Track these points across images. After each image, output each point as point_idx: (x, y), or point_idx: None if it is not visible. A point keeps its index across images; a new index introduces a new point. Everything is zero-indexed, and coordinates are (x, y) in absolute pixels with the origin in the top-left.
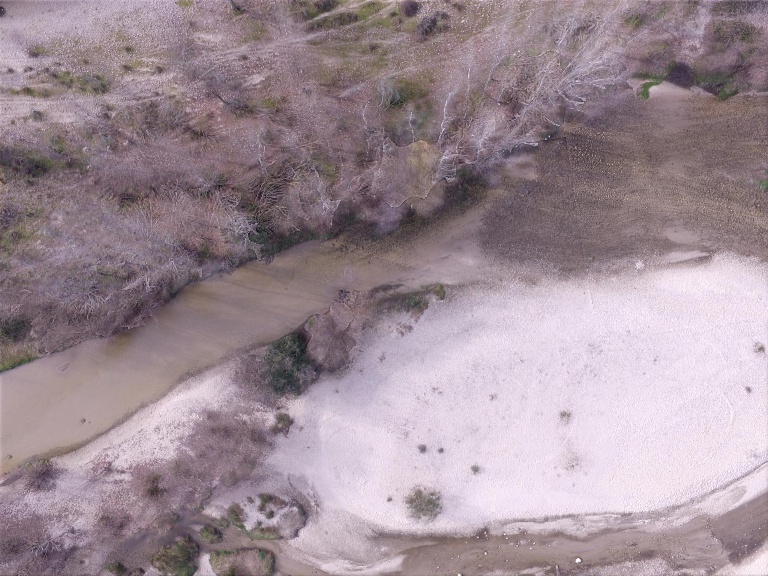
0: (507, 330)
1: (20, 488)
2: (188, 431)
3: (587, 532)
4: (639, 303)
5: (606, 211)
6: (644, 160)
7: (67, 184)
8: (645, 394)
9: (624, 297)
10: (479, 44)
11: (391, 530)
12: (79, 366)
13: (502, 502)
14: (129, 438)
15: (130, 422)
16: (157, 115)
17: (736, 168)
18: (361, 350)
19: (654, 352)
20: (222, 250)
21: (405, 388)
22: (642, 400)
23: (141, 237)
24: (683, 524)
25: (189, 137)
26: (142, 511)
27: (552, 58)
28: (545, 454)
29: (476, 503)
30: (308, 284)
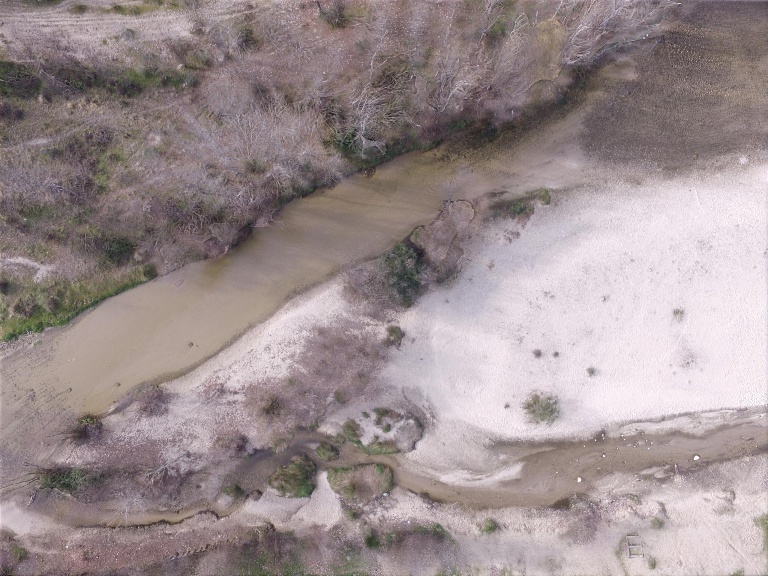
0: (615, 231)
1: (131, 415)
2: (299, 348)
3: (704, 429)
4: (745, 198)
5: (708, 108)
6: (743, 55)
7: (163, 104)
8: (757, 287)
9: (730, 192)
10: None
11: (508, 438)
12: (183, 289)
13: (619, 403)
14: (239, 359)
15: (239, 343)
16: (252, 29)
17: None
18: (469, 259)
19: (764, 245)
20: (325, 164)
21: (516, 294)
22: (754, 293)
23: (242, 154)
24: None
25: (286, 50)
26: (257, 431)
27: None
28: (660, 352)
29: (593, 405)
30: (412, 195)
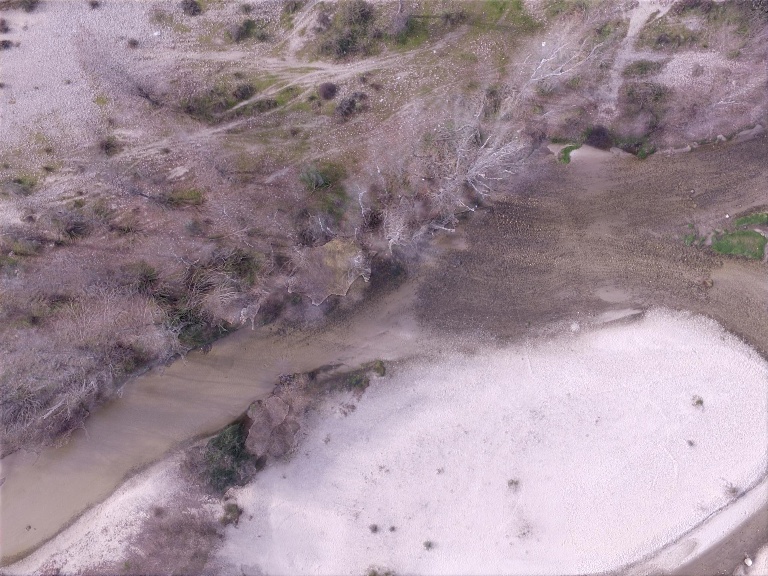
0: (449, 402)
1: None
2: (136, 530)
3: None
4: (577, 365)
5: (538, 276)
6: (571, 223)
7: None
8: (590, 456)
9: (562, 360)
10: (399, 121)
11: None
12: (20, 472)
13: (457, 575)
14: (76, 542)
15: (76, 525)
16: (82, 214)
17: (661, 224)
18: (305, 433)
19: (595, 413)
20: (158, 344)
21: (352, 469)
22: (587, 462)
23: (74, 338)
24: None
25: (116, 234)
26: None
27: (469, 134)
28: (496, 524)
29: None
30: (248, 371)
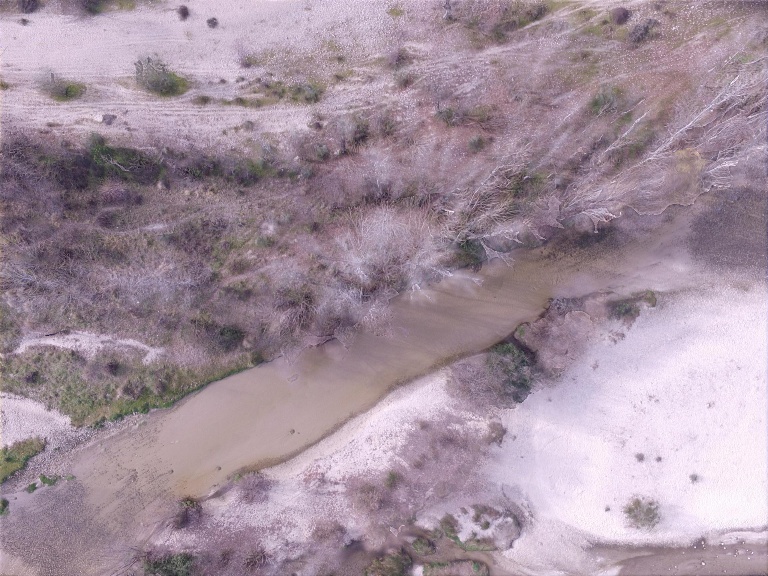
0: (722, 337)
1: (231, 500)
2: (401, 441)
3: None
4: None
5: None
6: None
7: (278, 194)
8: None
9: None
10: (690, 51)
11: (607, 540)
12: (288, 376)
13: (721, 511)
14: (340, 449)
15: (340, 433)
16: (368, 124)
17: None
18: (573, 358)
19: None
20: (434, 259)
21: (620, 396)
22: None
23: (352, 246)
24: None
25: (401, 146)
26: (355, 523)
27: None
28: (764, 462)
29: (694, 512)
30: (517, 292)
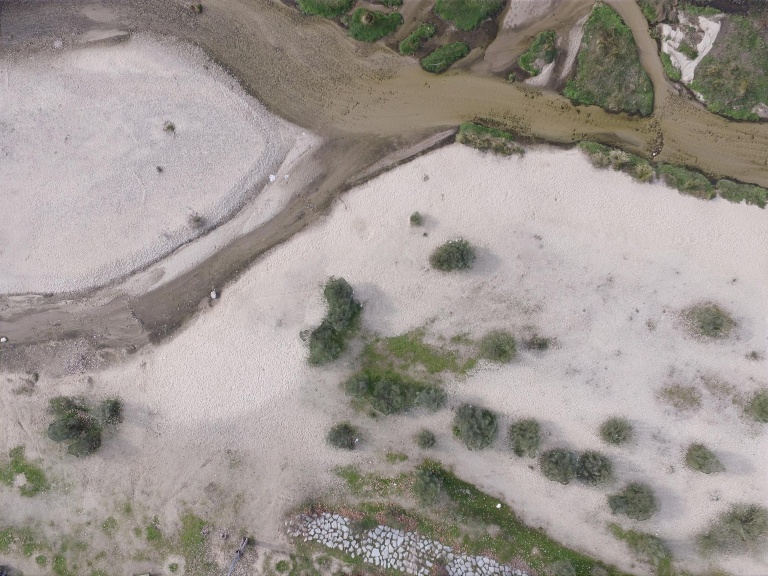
0: None
1: None
2: None
3: (11, 312)
4: (54, 82)
5: None
6: None
7: None
8: (57, 173)
9: (40, 76)
10: None
11: None
12: None
13: None
14: None
15: None
16: None
17: None
18: None
19: (65, 130)
20: None
21: None
22: (54, 179)
23: None
24: (104, 304)
25: None
26: None
27: None
28: None
29: None
30: None
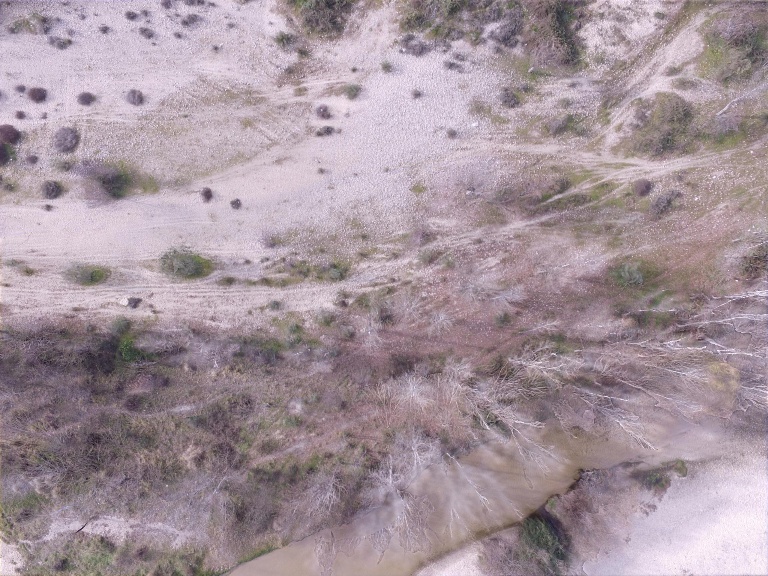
0: (754, 508)
1: None
2: None
3: None
4: None
5: None
6: None
7: (304, 372)
8: None
9: None
10: (713, 221)
11: None
12: None
13: None
14: None
15: None
16: (394, 301)
17: None
18: None
19: None
20: (463, 434)
21: (654, 571)
22: None
23: (381, 424)
24: None
25: (427, 322)
26: None
27: None
28: None
29: None
30: None
